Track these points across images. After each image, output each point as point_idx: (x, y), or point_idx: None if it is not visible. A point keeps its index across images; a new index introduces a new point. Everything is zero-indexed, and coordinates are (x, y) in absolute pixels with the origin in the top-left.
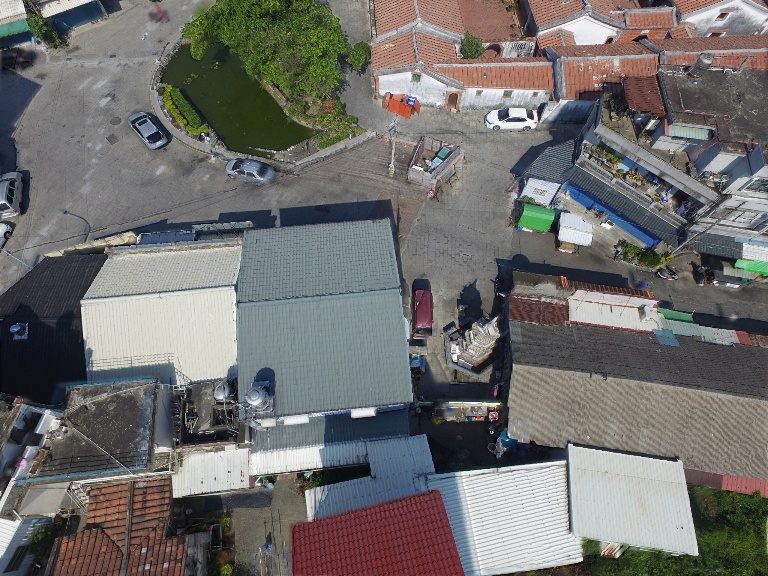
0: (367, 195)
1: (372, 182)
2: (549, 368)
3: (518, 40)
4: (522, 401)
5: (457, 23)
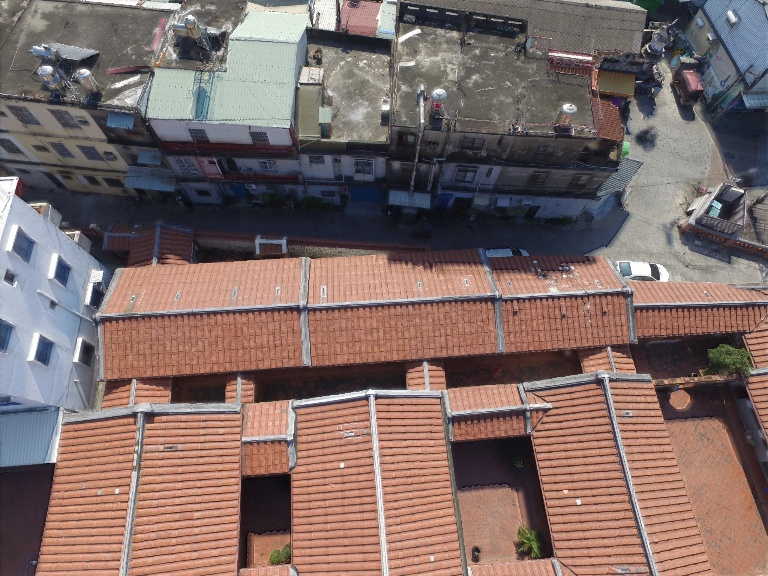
0: (763, 192)
1: (765, 202)
2: (624, 8)
3: (665, 380)
4: (631, 5)
5: (767, 403)
